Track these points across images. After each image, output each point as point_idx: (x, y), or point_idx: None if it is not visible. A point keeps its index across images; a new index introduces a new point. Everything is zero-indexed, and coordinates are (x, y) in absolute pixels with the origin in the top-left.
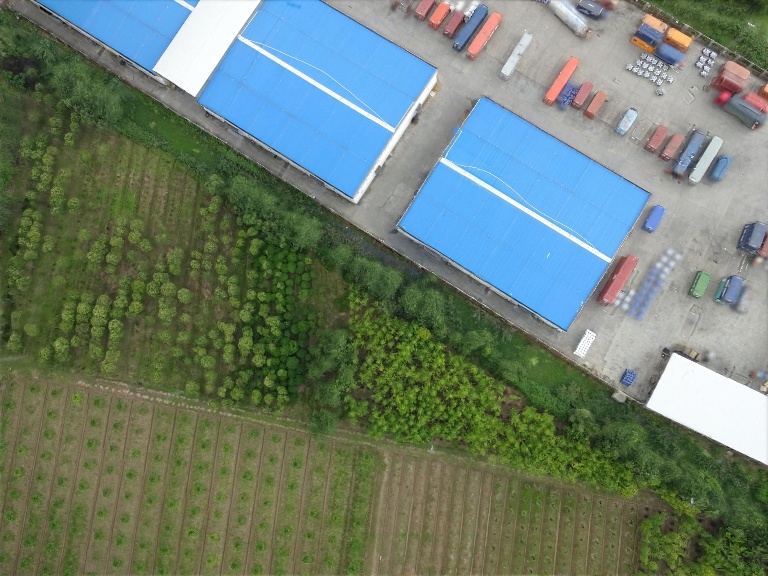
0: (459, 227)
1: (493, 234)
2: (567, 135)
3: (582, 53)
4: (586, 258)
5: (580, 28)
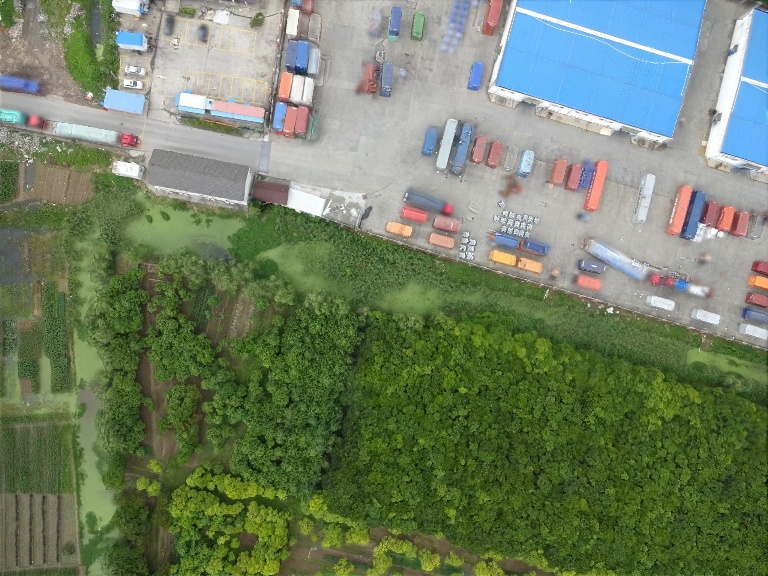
0: (654, 8)
1: (624, 7)
2: (573, 138)
3: (583, 223)
4: (537, 7)
5: (592, 247)
